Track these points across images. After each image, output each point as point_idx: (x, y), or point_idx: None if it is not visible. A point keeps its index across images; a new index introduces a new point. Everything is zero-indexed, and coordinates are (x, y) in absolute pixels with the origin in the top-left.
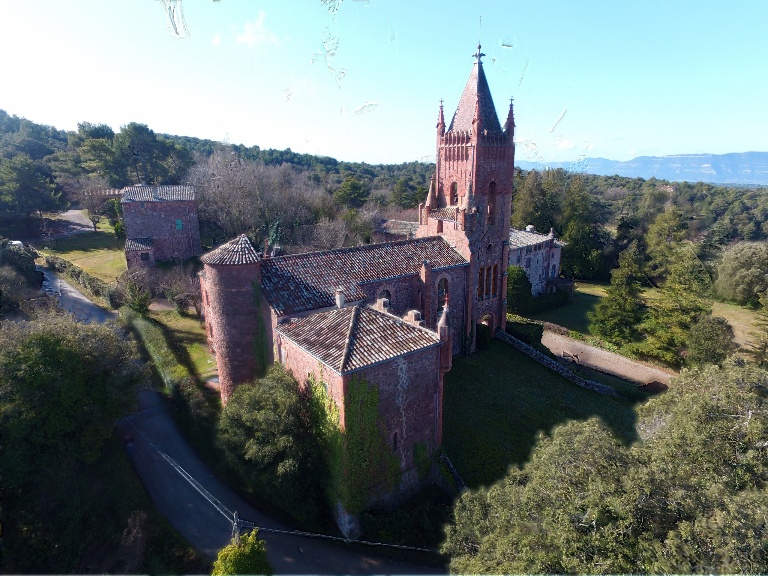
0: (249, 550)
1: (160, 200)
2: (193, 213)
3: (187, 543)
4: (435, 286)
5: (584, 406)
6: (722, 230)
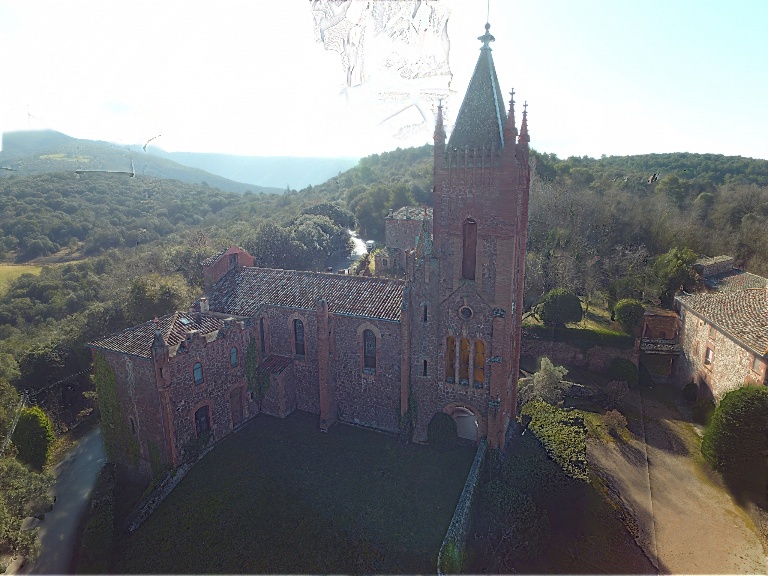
0: (20, 414)
1: (407, 219)
2: None
3: None
4: (358, 335)
5: None
6: None
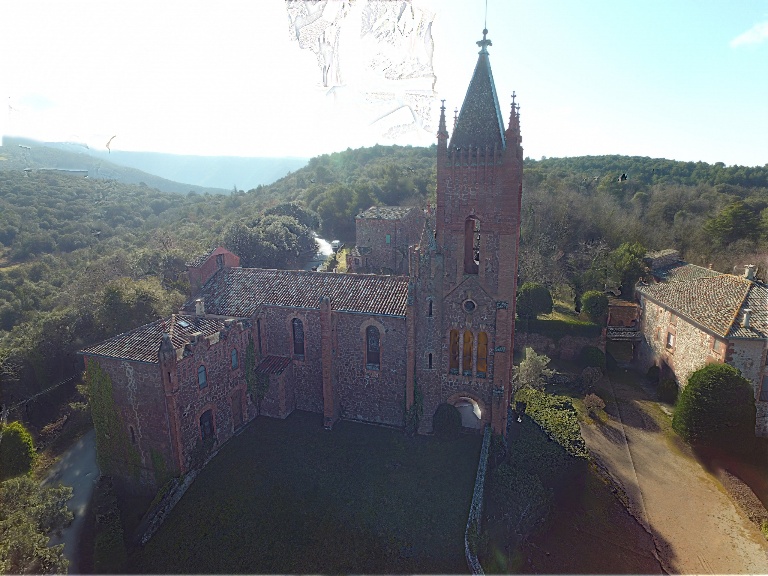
0: None
1: (378, 218)
2: (399, 231)
3: (86, 432)
4: (361, 332)
5: (410, 574)
6: None
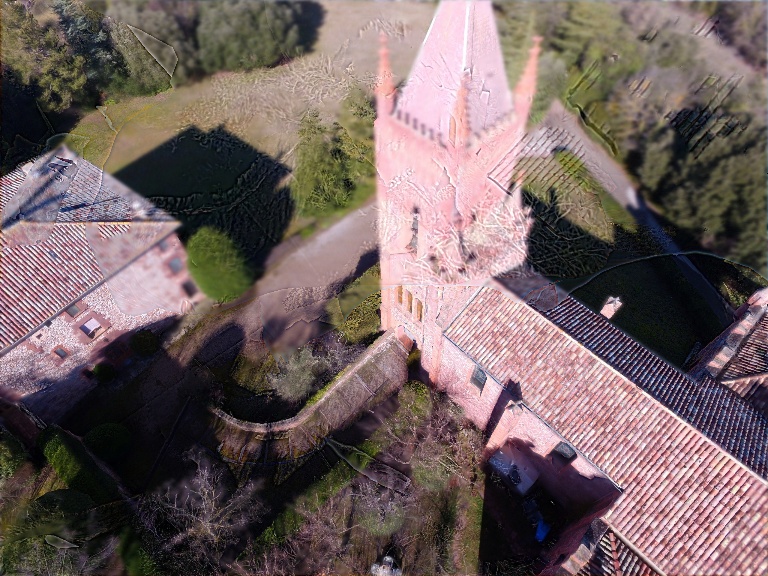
0: None
1: None
2: None
3: None
4: None
5: None
6: (72, 5)
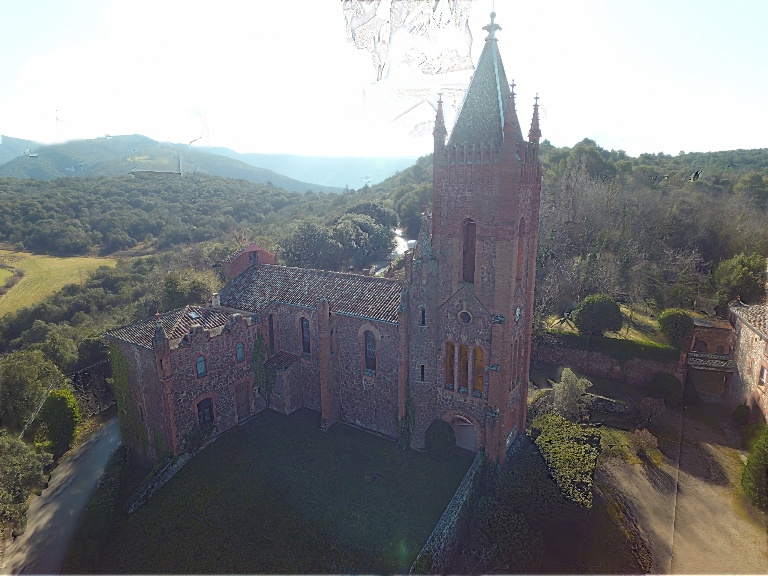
0: (51, 395)
1: None
2: None
3: None
4: (359, 336)
5: None
6: None
